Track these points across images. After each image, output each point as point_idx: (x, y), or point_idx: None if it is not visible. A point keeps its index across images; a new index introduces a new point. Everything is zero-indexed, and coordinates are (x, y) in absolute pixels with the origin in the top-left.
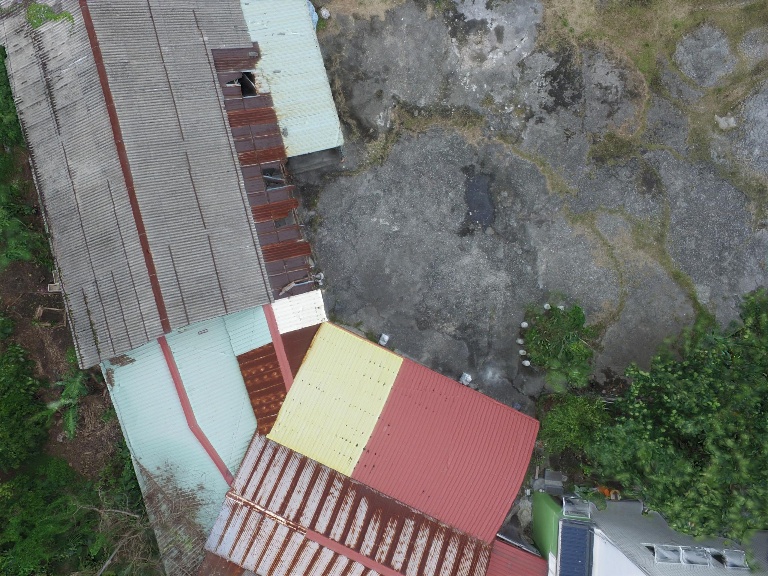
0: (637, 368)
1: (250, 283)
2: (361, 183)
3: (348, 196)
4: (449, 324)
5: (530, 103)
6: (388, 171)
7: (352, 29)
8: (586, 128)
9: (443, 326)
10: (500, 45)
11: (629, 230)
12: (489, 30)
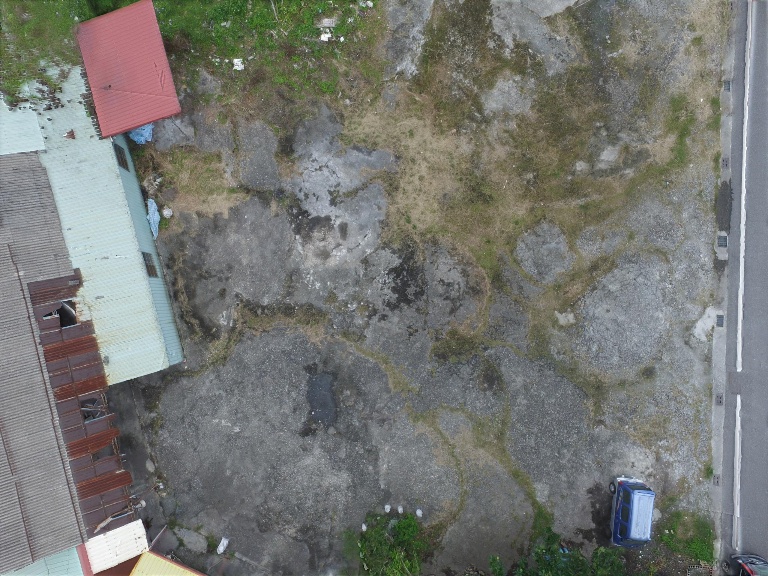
0: (476, 568)
1: (61, 525)
2: (203, 383)
3: (190, 397)
4: (290, 526)
5: (373, 300)
6: (230, 371)
7: (195, 227)
8: (428, 325)
9: (284, 528)
10: (343, 242)
11: (470, 428)
12: (333, 227)
